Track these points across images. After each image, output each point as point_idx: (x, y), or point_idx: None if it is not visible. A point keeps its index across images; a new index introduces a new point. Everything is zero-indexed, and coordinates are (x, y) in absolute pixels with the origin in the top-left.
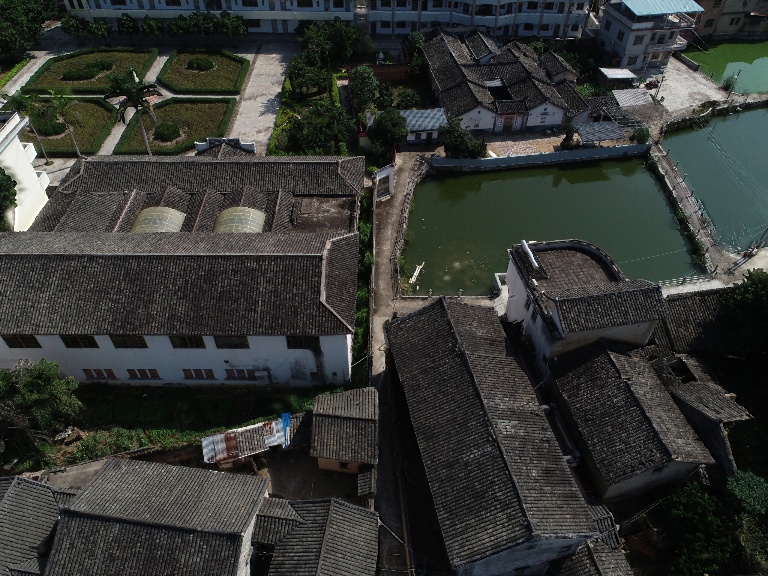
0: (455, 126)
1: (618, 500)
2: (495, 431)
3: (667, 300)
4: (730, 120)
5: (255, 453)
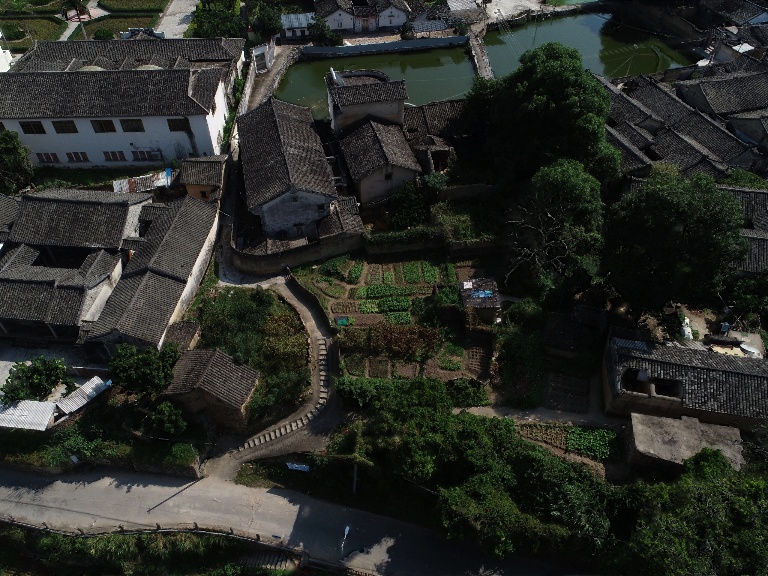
0: (317, 21)
1: (374, 207)
2: (284, 149)
3: (428, 105)
4: (546, 26)
5: (148, 190)
